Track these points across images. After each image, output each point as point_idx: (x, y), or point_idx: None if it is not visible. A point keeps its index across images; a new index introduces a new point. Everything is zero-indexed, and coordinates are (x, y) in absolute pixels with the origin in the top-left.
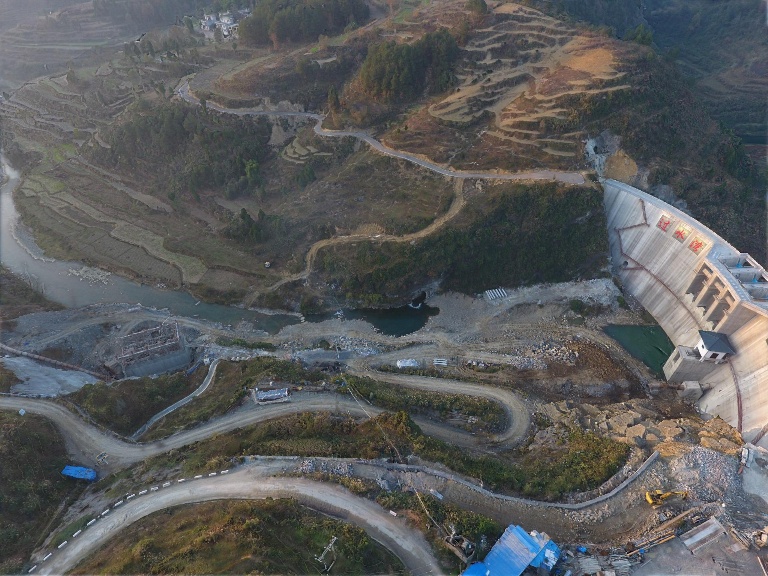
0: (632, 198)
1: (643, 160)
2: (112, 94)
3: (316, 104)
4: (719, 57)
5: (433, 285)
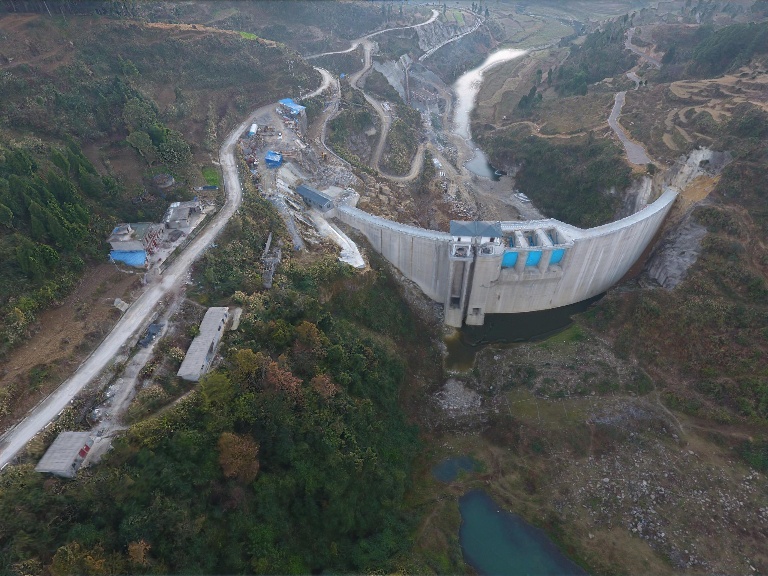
0: None
1: (724, 198)
2: None
3: None
4: None
5: None
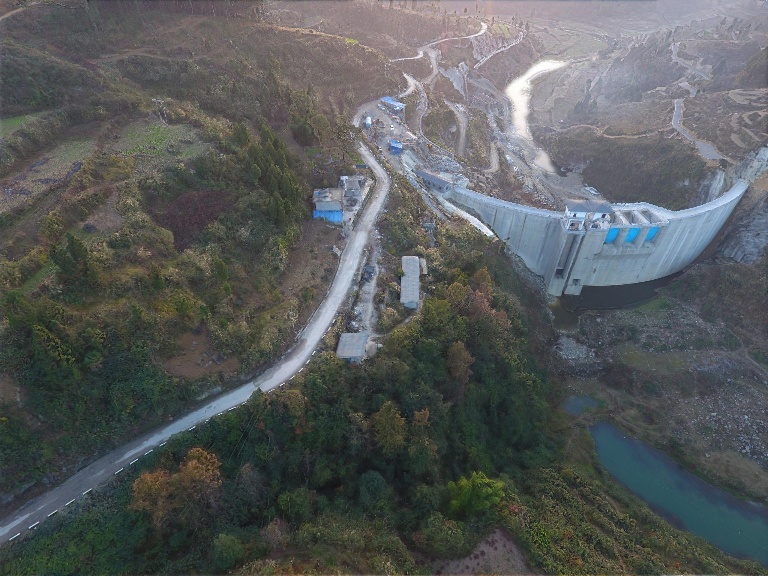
0: None
1: None
2: None
3: None
4: None
5: (581, 167)
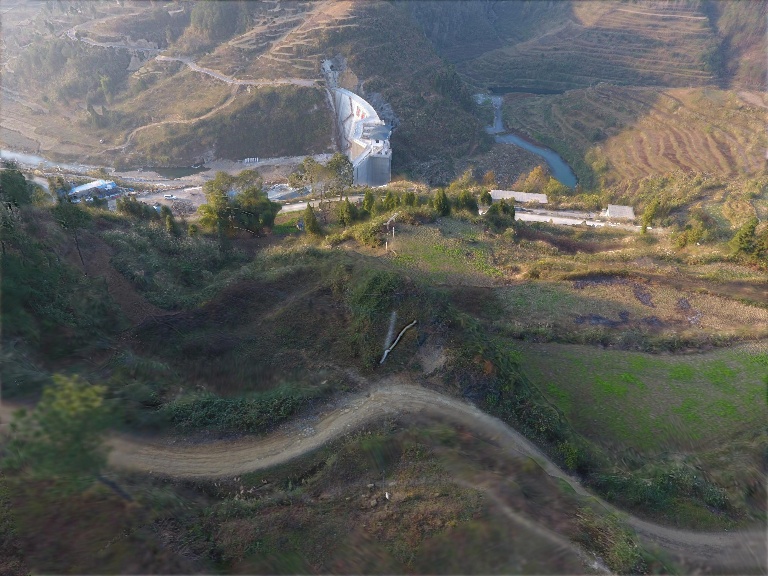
0: (347, 98)
1: (364, 76)
2: (26, 38)
3: (167, 43)
4: (533, 34)
5: (209, 154)
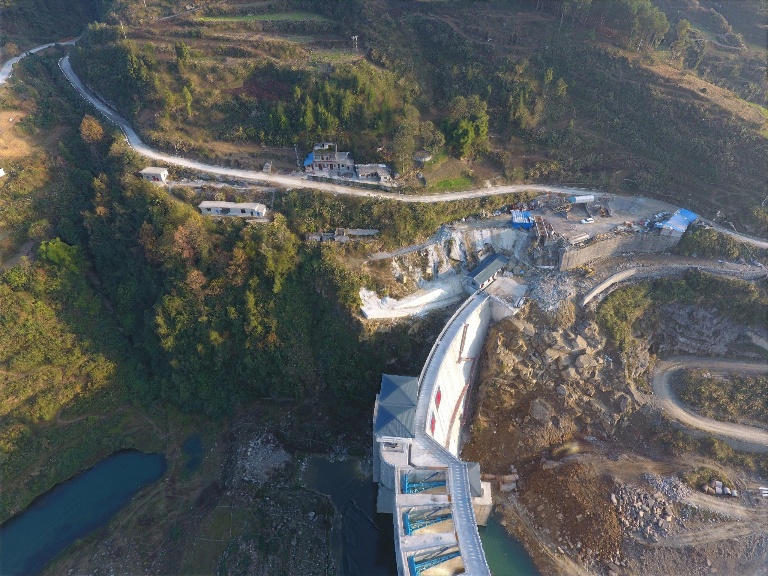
0: None
1: None
2: None
3: None
4: None
5: None
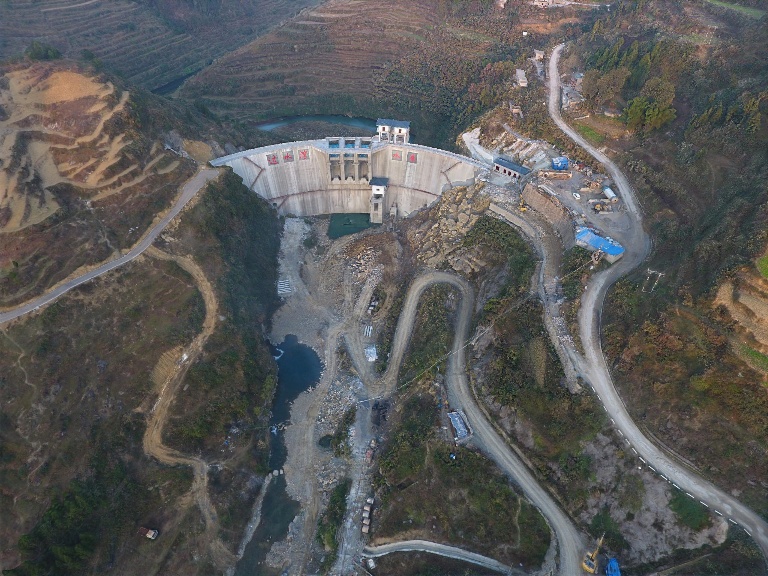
0: (237, 162)
1: (199, 138)
2: None
3: None
4: None
5: (262, 329)
